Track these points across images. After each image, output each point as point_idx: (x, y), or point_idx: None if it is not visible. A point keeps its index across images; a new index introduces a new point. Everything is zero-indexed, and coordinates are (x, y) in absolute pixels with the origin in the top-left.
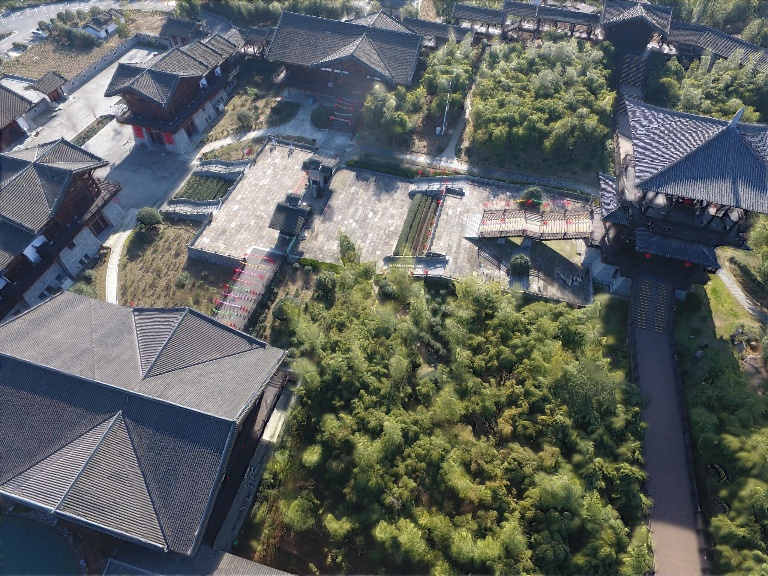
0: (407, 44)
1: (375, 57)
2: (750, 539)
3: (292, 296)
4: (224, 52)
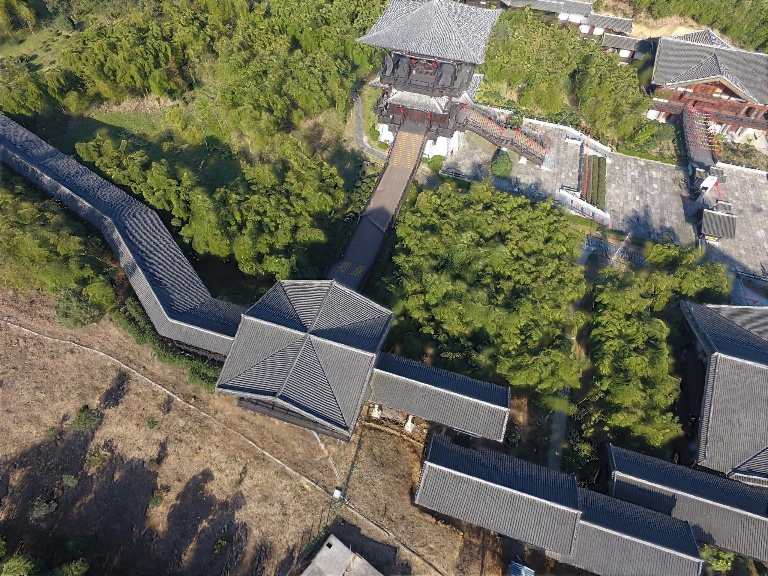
0: (733, 348)
1: (767, 335)
2: None
3: None
4: None
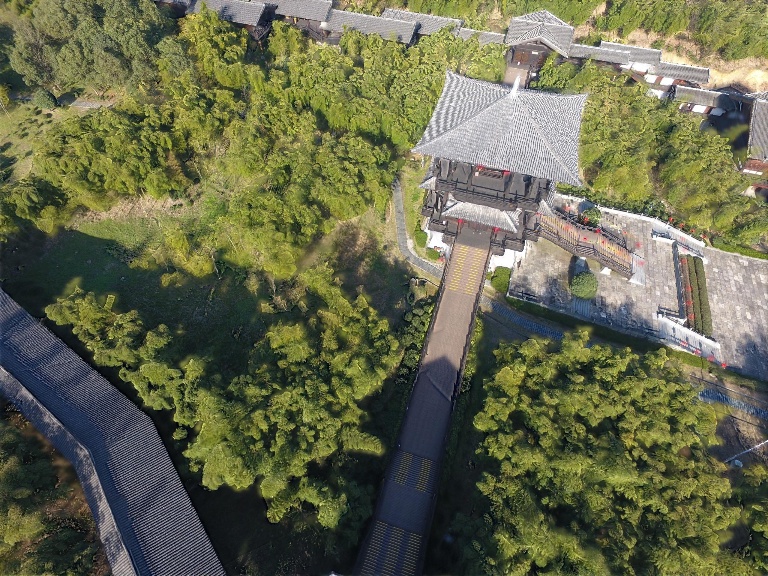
0: None
1: None
2: (495, 67)
3: (767, 239)
4: None
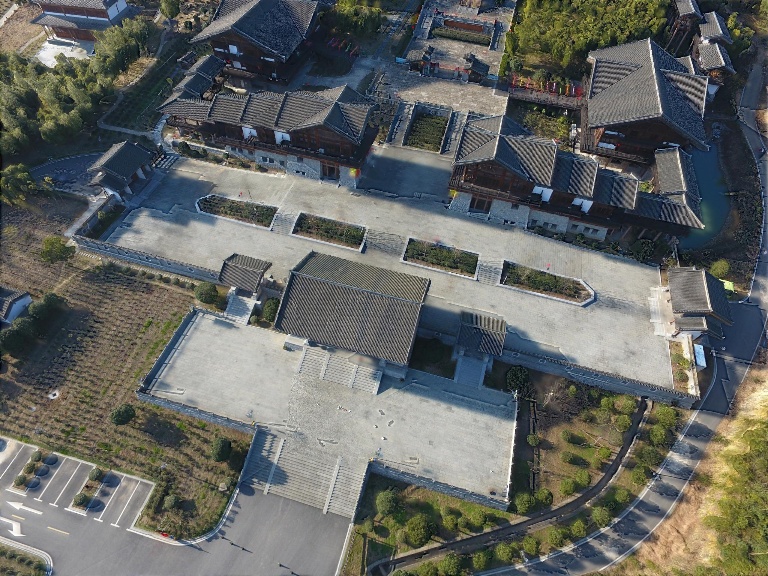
0: None
1: None
2: None
3: None
4: (246, 97)
